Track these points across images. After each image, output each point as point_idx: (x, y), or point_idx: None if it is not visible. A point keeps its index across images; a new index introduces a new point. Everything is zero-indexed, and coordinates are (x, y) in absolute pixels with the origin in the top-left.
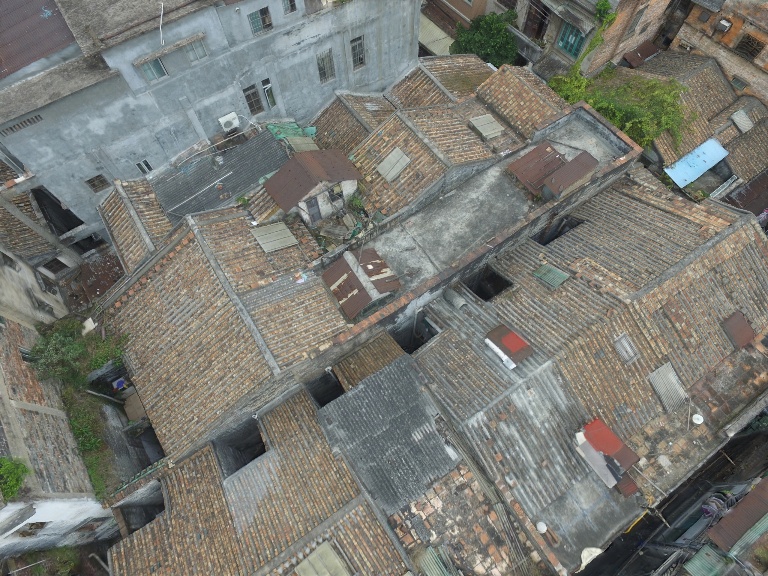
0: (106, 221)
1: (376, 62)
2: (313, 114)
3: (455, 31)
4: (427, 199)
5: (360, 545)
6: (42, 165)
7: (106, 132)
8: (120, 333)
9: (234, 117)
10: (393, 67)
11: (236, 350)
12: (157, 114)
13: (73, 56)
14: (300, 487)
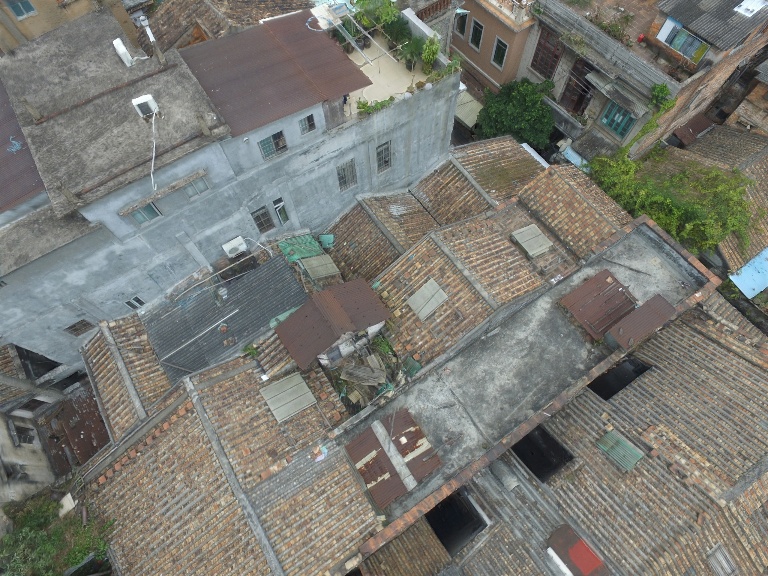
0: (90, 368)
1: (403, 162)
2: (330, 220)
3: (483, 98)
4: (468, 343)
5: None
6: (10, 325)
7: (87, 281)
8: (104, 517)
9: (240, 243)
10: (421, 163)
11: (243, 568)
12: (149, 253)
13: (46, 203)
14: None
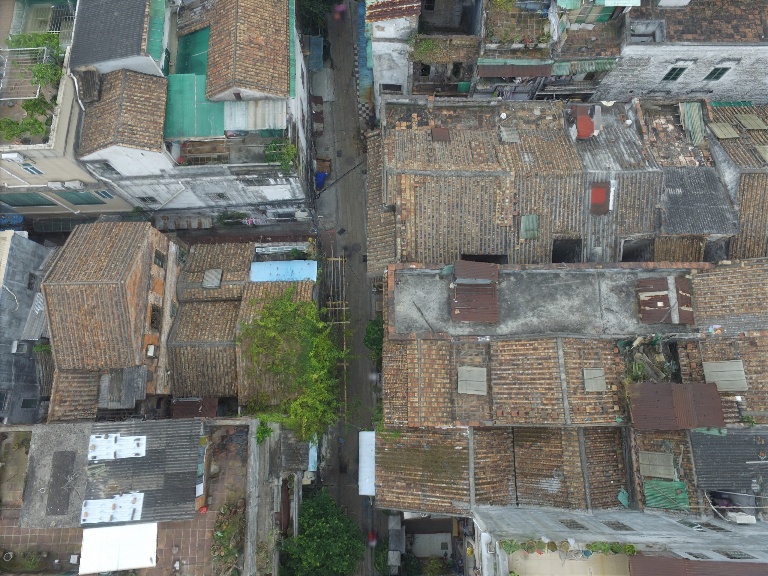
0: None
1: None
2: None
3: None
4: None
5: (745, 158)
6: None
7: None
8: None
9: (738, 516)
10: None
11: None
12: None
13: None
14: (767, 202)
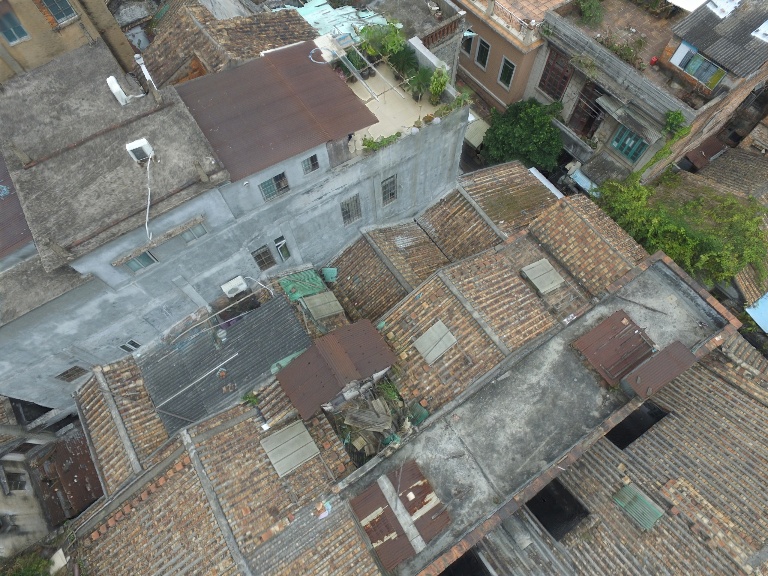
0: (83, 415)
1: (409, 193)
2: (333, 253)
3: (489, 118)
4: None
5: None
6: None
7: (80, 330)
8: (97, 575)
9: (240, 283)
10: (428, 193)
11: None
12: (145, 299)
13: (35, 252)
14: None
